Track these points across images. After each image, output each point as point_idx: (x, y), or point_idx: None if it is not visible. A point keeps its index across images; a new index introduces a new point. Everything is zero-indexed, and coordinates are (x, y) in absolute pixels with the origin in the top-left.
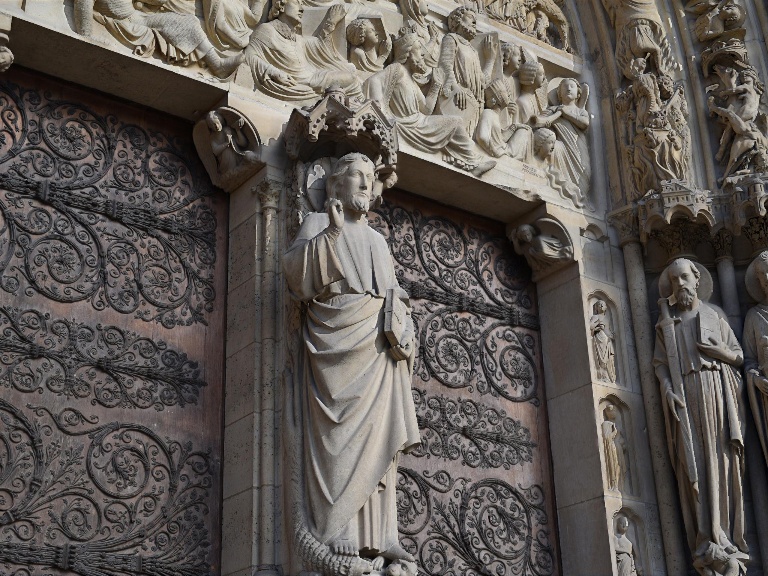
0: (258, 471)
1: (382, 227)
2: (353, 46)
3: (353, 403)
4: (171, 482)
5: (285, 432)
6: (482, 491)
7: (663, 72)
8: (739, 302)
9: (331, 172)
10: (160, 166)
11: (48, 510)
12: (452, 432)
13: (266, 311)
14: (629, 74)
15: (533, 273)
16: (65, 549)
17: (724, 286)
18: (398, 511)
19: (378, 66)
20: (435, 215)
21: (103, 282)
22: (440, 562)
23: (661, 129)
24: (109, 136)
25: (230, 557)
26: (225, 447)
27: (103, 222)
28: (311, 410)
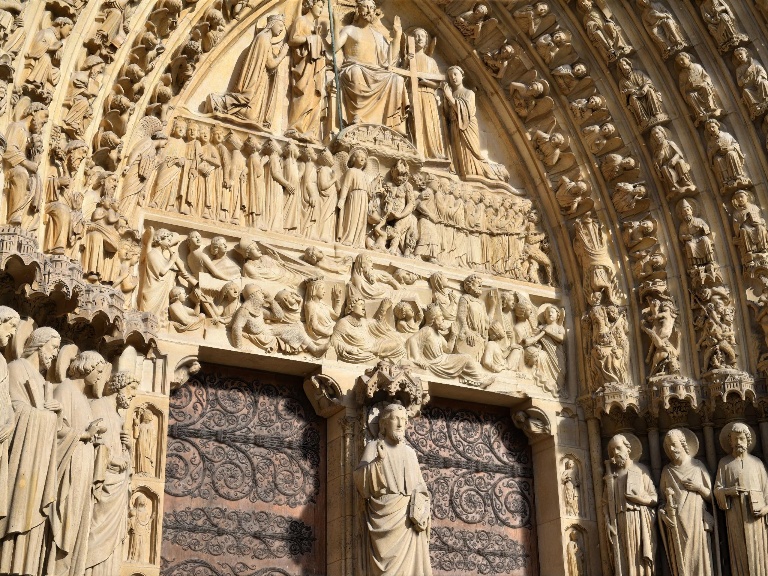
0: None
1: (425, 423)
2: (399, 319)
3: (393, 560)
4: None
5: (358, 573)
6: None
7: (613, 301)
8: (661, 459)
9: (381, 416)
10: (285, 408)
11: None
12: (471, 553)
13: (347, 499)
14: (590, 303)
15: (529, 440)
16: None
17: (651, 448)
18: None
19: (415, 329)
20: (461, 409)
21: (255, 485)
22: None
23: (607, 346)
24: (255, 395)
25: None
26: None
27: (254, 448)
28: (371, 562)
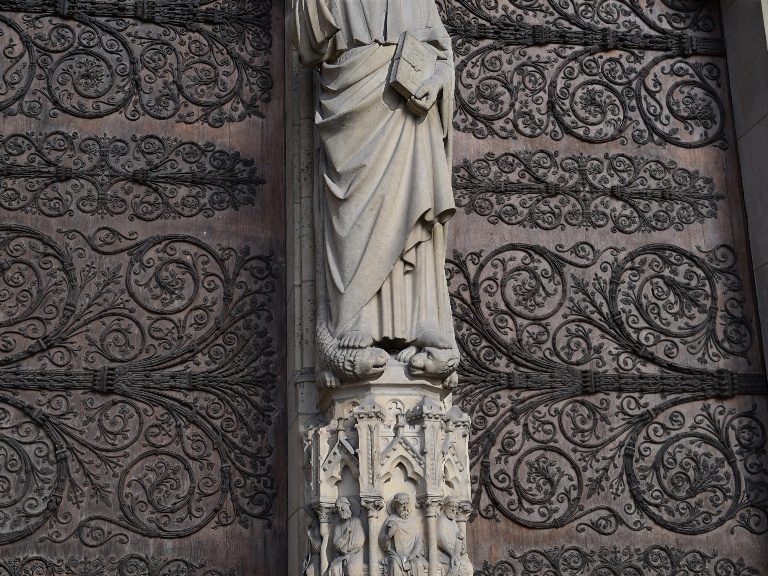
0: (300, 267)
1: None
2: None
3: (358, 173)
4: (225, 291)
5: None
6: (641, 260)
7: None
8: None
9: None
10: None
11: (85, 334)
12: (596, 195)
13: (300, 88)
14: None
15: None
16: (103, 371)
17: None
18: (521, 295)
19: None
20: None
21: (137, 90)
22: (581, 348)
23: None
24: None
25: (289, 364)
26: (286, 247)
27: (134, 26)
28: None
